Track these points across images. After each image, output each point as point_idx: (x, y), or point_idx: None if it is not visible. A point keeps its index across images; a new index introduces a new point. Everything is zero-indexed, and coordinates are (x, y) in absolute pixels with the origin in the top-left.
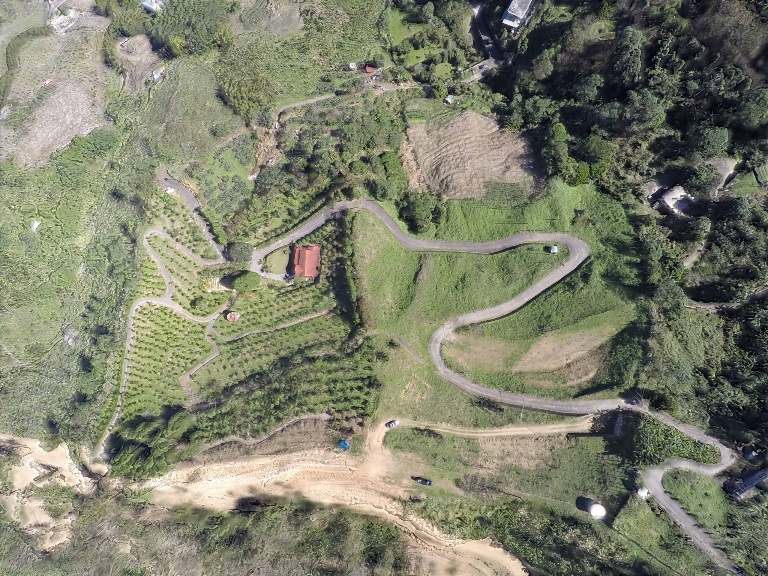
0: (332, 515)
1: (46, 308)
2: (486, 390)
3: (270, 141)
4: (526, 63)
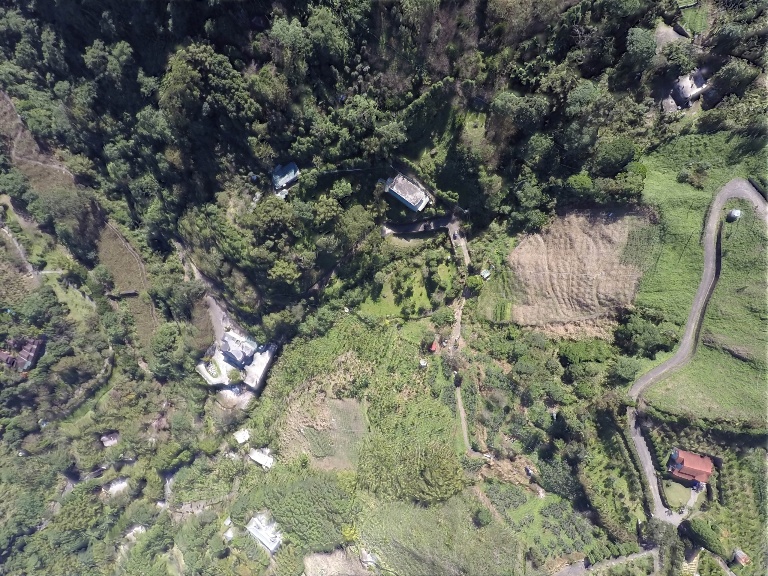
0: None
1: None
2: None
3: (503, 466)
4: (473, 197)
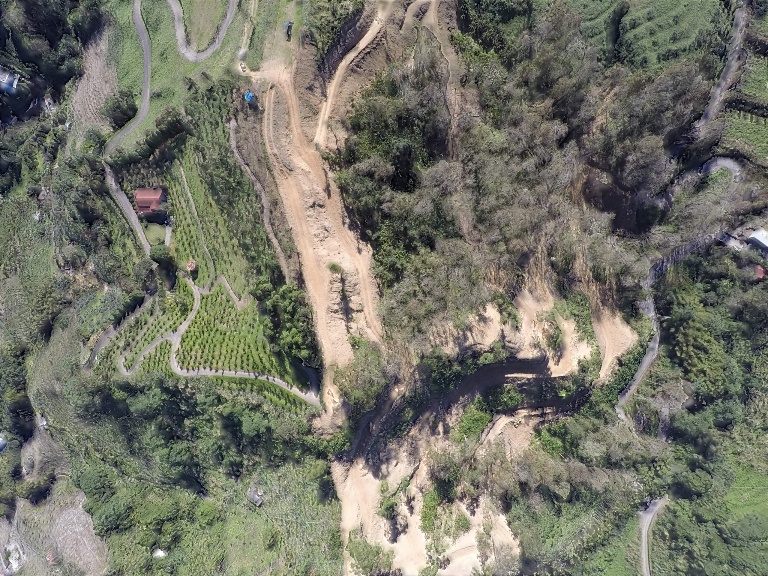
0: (343, 122)
1: (232, 530)
2: (231, 5)
3: (79, 274)
4: None
